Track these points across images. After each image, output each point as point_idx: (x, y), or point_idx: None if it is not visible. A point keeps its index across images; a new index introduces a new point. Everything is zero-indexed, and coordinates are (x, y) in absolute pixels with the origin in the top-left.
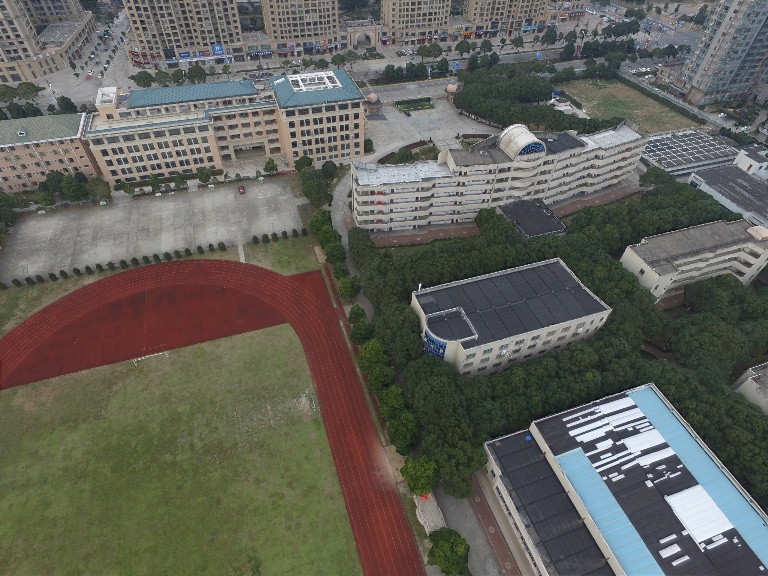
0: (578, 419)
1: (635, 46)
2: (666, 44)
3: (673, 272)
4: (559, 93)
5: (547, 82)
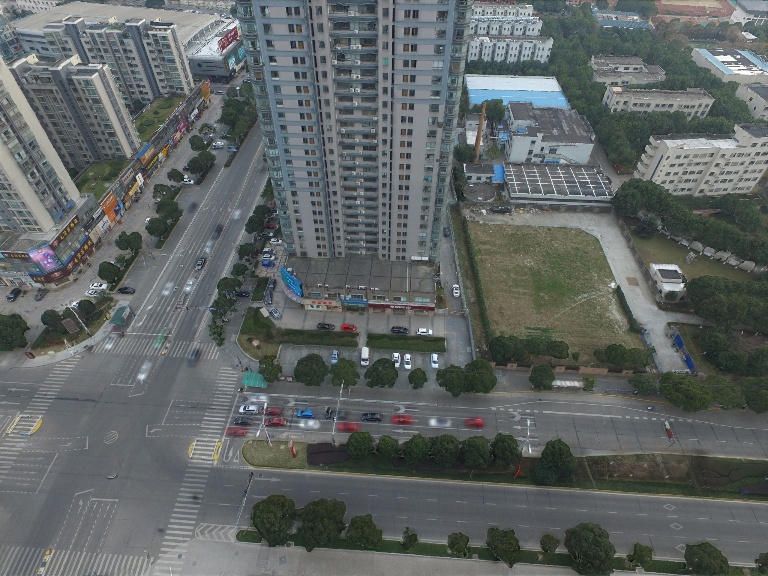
0: (765, 74)
1: (292, 490)
2: (196, 471)
3: (693, 88)
4: (641, 330)
5: (710, 279)
